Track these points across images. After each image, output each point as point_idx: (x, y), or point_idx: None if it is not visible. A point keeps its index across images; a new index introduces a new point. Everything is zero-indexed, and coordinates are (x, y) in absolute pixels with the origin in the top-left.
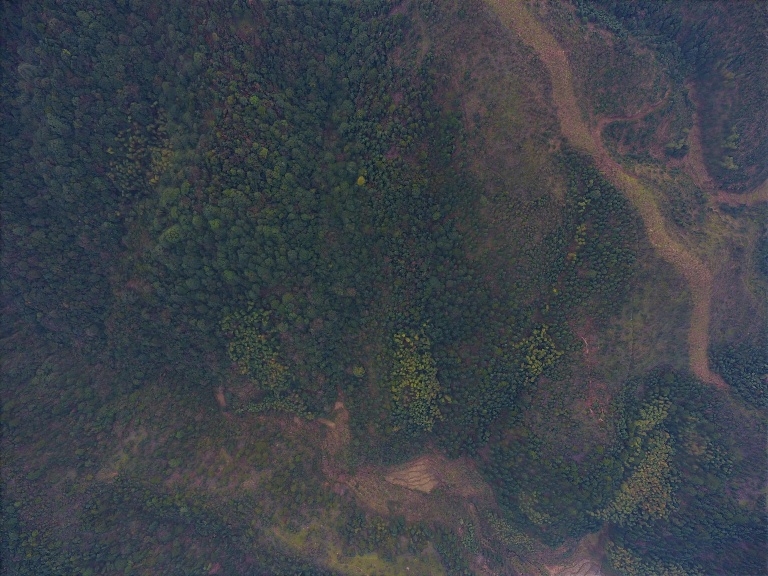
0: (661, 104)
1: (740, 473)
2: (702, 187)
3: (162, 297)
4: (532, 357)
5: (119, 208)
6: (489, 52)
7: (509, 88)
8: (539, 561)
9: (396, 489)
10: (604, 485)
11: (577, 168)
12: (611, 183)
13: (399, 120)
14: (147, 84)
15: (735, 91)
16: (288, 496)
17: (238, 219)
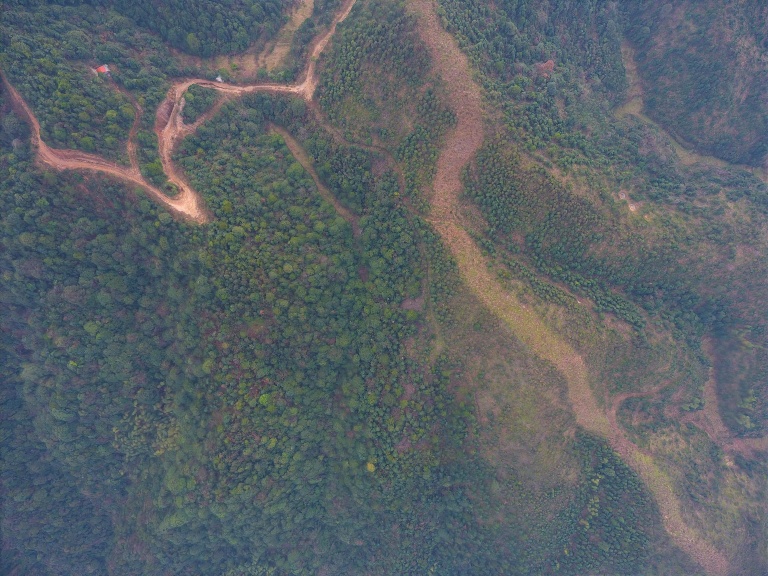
0: (677, 375)
1: None
2: (717, 437)
3: None
4: None
5: (123, 467)
6: (504, 360)
7: (524, 398)
8: None
9: None
10: None
11: (591, 448)
12: (626, 462)
13: (411, 414)
14: (154, 367)
15: (753, 356)
16: None
17: (244, 508)
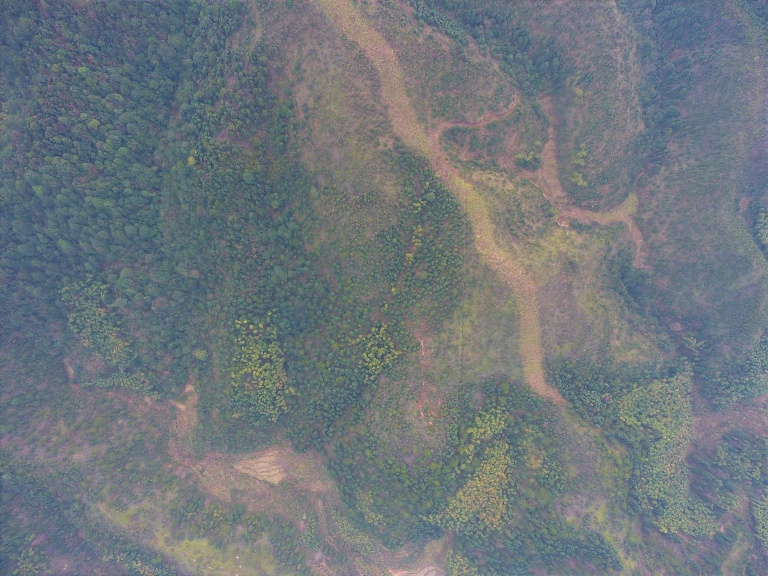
0: (507, 114)
1: (572, 490)
2: (555, 201)
3: None
4: (369, 355)
5: None
6: (316, 44)
7: (332, 81)
8: (383, 564)
9: (243, 478)
10: (433, 490)
11: (413, 169)
12: (446, 186)
13: (230, 104)
14: None
15: (585, 108)
16: (122, 474)
17: (63, 187)
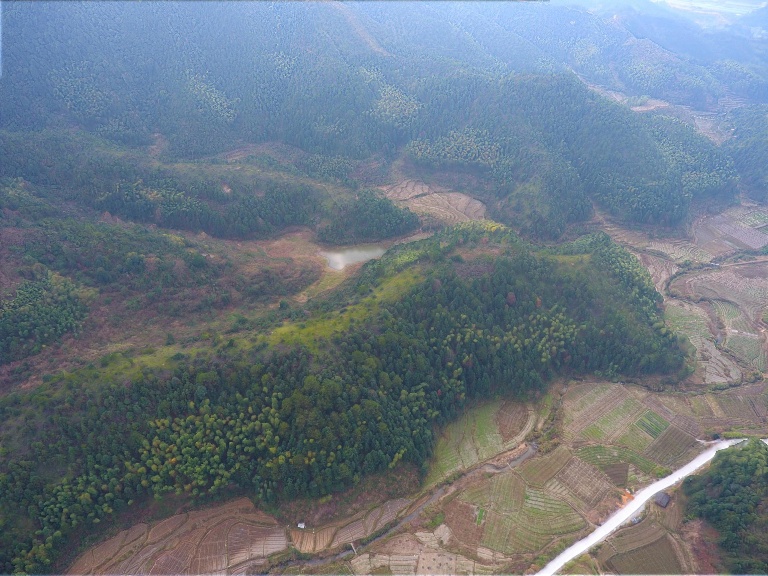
0: None
1: None
2: None
3: (3, 52)
4: None
5: None
6: None
7: None
8: (368, 184)
9: None
10: (359, 89)
11: None
12: None
13: None
14: None
15: None
16: None
17: None
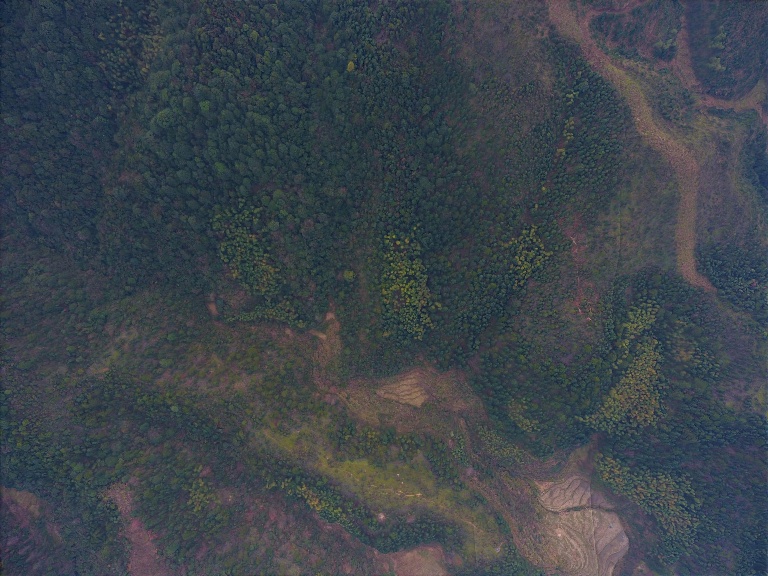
0: None
1: (727, 376)
2: (690, 91)
3: (153, 189)
4: (521, 258)
5: (111, 102)
6: None
7: None
8: (529, 476)
9: (387, 402)
10: (592, 387)
11: (565, 59)
12: (599, 74)
13: (388, 3)
14: None
15: None
16: (279, 401)
17: (228, 102)
